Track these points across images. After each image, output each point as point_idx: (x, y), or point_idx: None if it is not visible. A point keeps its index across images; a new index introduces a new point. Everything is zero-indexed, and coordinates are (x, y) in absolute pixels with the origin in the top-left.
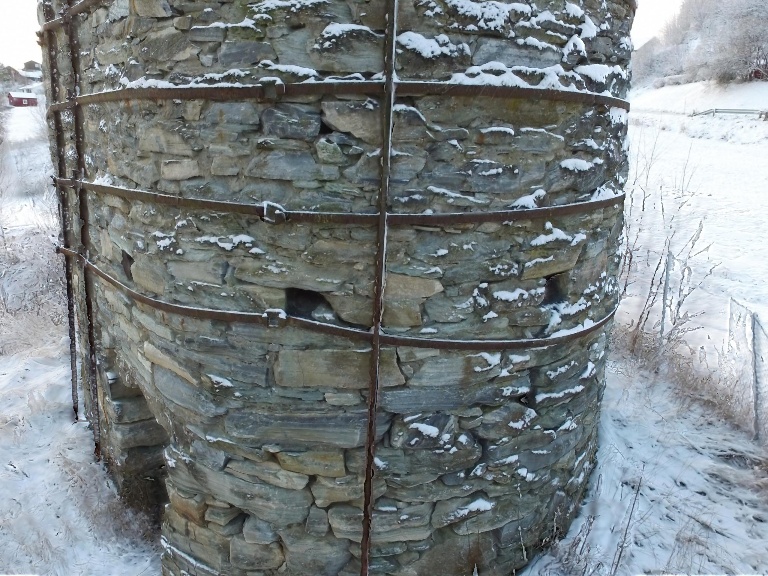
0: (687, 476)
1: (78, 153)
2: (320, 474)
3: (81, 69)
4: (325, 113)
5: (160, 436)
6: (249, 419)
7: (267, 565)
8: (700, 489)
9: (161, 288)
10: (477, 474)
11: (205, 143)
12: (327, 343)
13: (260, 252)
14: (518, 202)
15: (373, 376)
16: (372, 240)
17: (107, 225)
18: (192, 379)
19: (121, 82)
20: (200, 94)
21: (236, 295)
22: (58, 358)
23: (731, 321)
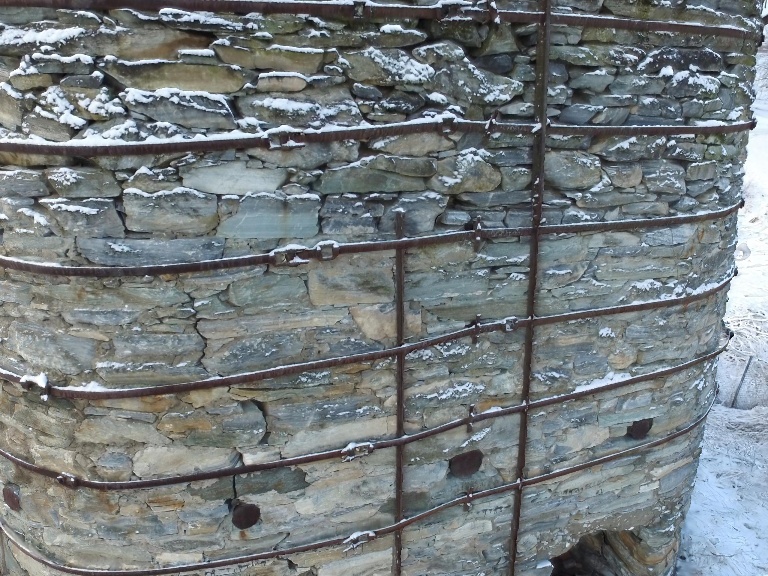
0: None
1: None
2: None
3: None
4: None
5: None
6: None
7: (680, 533)
8: None
9: None
10: None
11: None
12: None
13: None
14: None
15: None
16: None
17: None
18: None
19: None
20: None
21: None
22: None
23: None
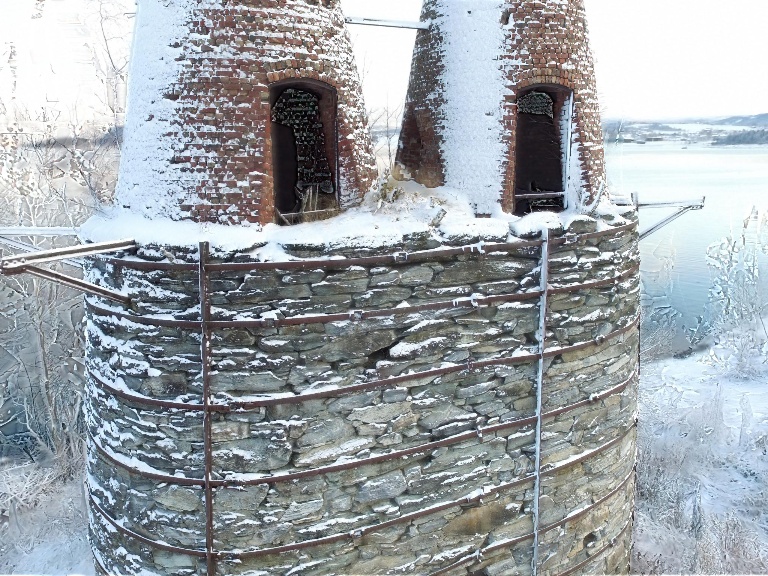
0: None
1: None
2: None
3: None
4: None
5: None
6: None
7: None
8: None
9: None
10: None
11: None
12: None
13: None
14: None
15: None
16: None
17: None
18: None
19: None
20: None
21: None
22: None
23: None
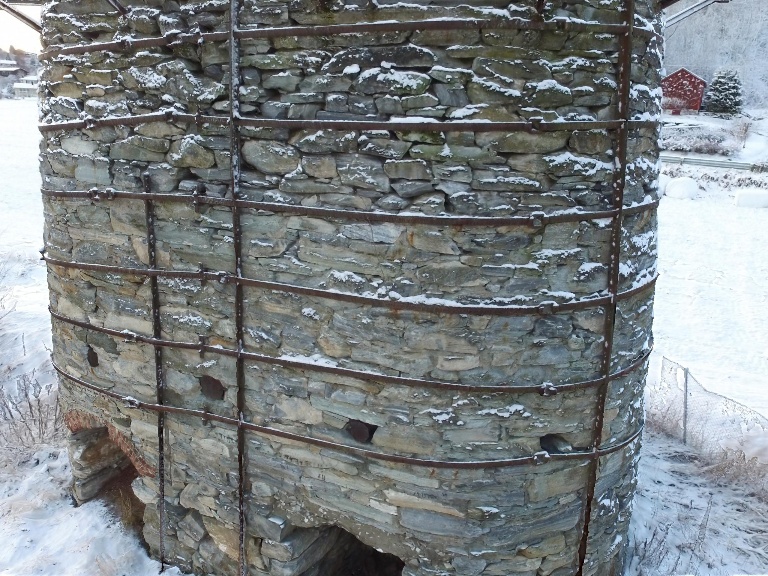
0: (661, 476)
1: (237, 327)
2: (551, 554)
3: (243, 253)
4: (578, 320)
5: (312, 560)
6: (510, 531)
7: None
8: (671, 483)
9: (429, 450)
10: (619, 520)
11: (488, 344)
12: (565, 465)
13: (529, 415)
14: (644, 347)
15: (595, 480)
16: (595, 393)
17: (308, 395)
18: (459, 513)
19: (390, 296)
20: (490, 312)
21: (511, 447)
22: (44, 507)
23: (663, 371)
